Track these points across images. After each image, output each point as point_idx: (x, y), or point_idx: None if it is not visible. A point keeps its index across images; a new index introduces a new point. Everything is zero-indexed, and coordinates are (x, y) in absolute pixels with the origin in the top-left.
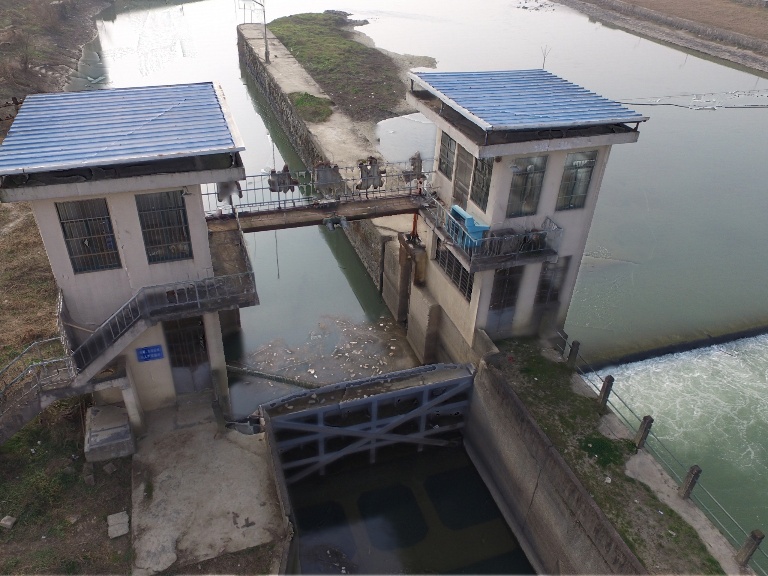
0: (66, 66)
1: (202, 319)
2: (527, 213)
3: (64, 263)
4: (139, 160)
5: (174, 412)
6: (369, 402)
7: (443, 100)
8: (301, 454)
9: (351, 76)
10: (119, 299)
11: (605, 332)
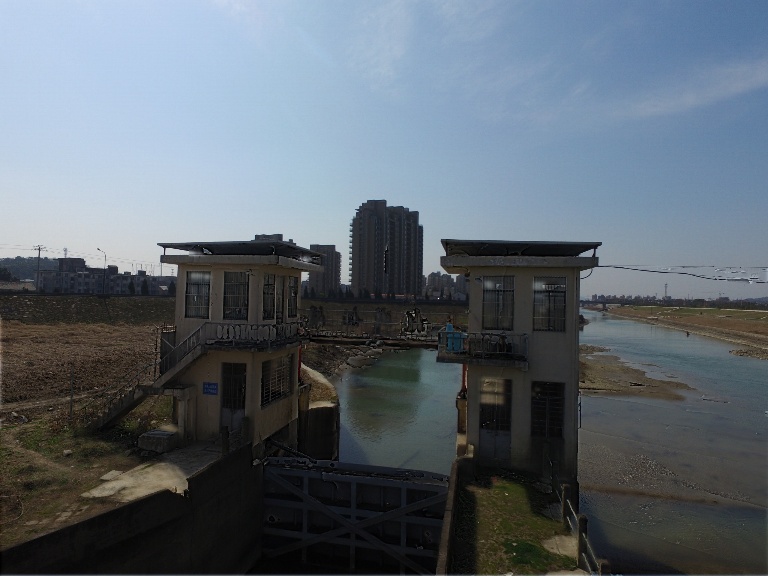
0: (359, 350)
1: (245, 369)
2: (504, 328)
3: (182, 309)
4: (223, 243)
5: (212, 444)
6: (349, 482)
7: None
8: (291, 527)
9: None
10: None
11: (698, 553)
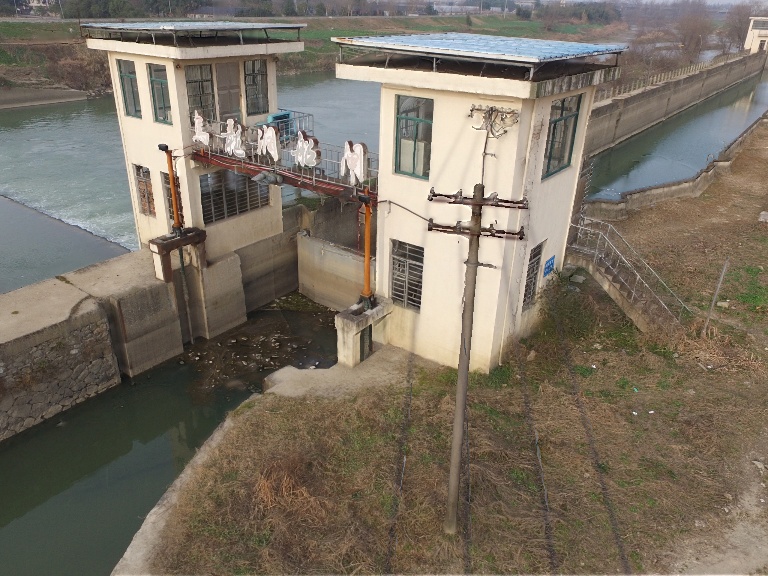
0: None
1: None
2: None
3: None
4: None
5: None
6: None
7: (253, 26)
8: None
9: None
10: None
11: None
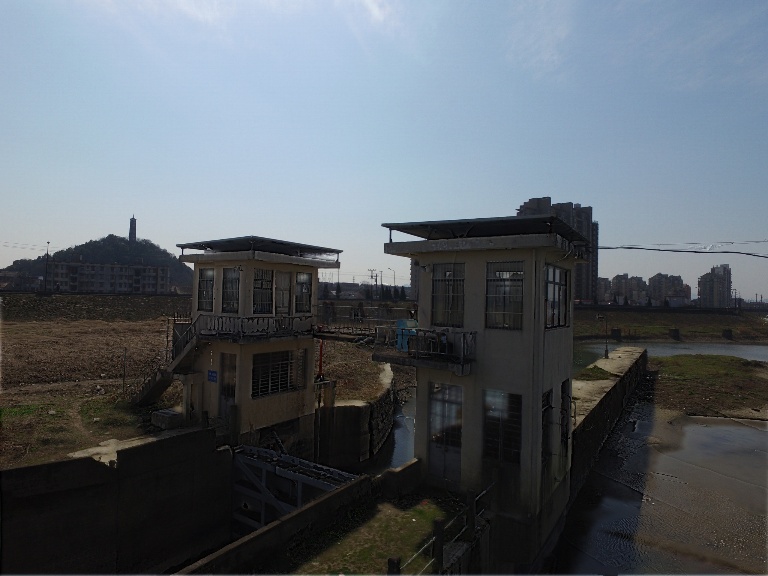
0: None
1: None
2: (454, 324)
3: None
4: (215, 241)
5: None
6: (296, 480)
7: None
8: (257, 517)
9: (700, 385)
10: (208, 332)
11: None
